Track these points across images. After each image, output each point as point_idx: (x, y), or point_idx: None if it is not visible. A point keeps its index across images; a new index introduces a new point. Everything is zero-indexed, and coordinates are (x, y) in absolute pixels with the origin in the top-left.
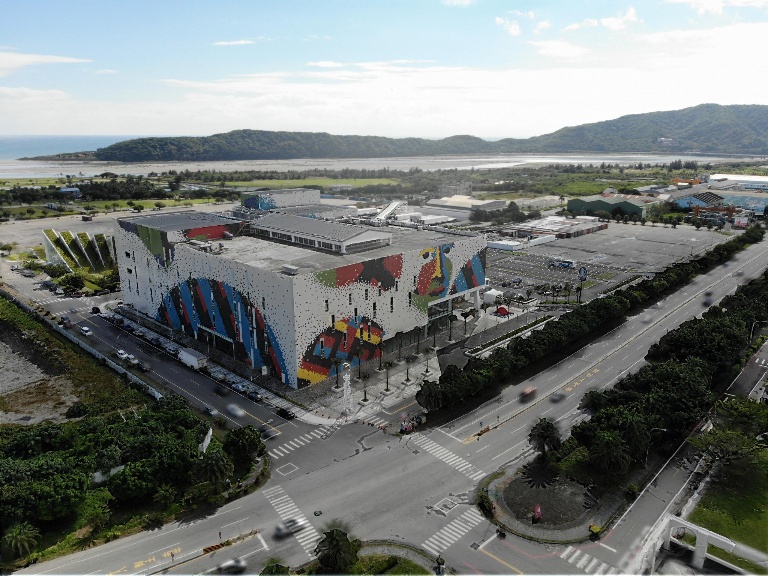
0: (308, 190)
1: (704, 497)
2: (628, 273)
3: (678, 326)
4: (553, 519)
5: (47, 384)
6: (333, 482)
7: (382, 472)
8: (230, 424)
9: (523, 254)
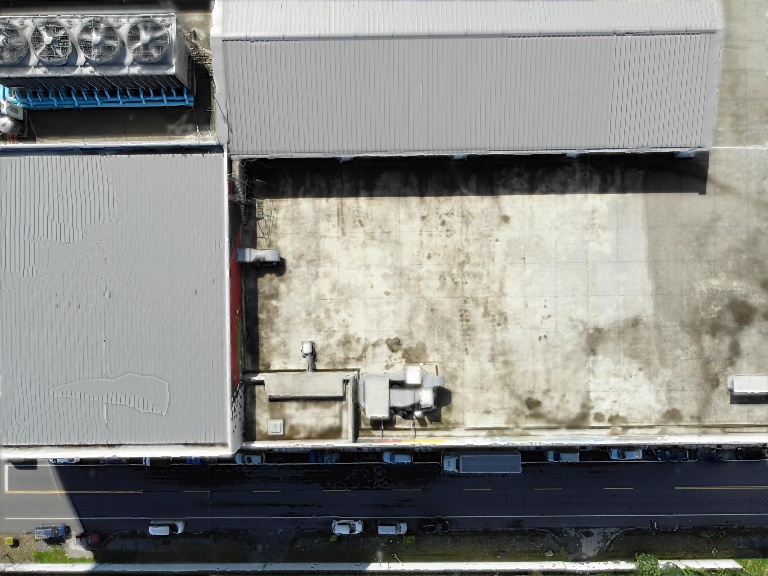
0: None
1: None
2: None
3: None
4: None
5: None
6: None
7: None
8: (715, 523)
9: None
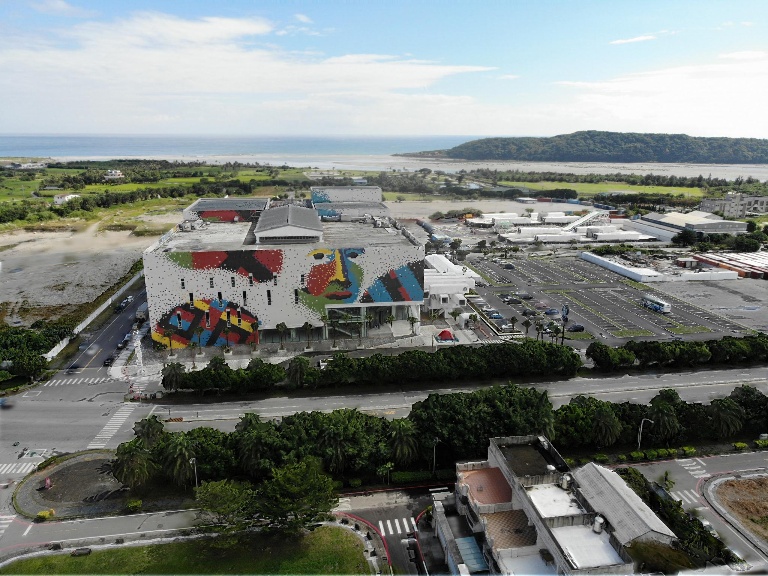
0: (369, 188)
1: (170, 544)
2: (734, 333)
3: None
4: (50, 494)
5: (65, 307)
6: (28, 411)
7: (60, 417)
8: (75, 357)
9: (643, 287)
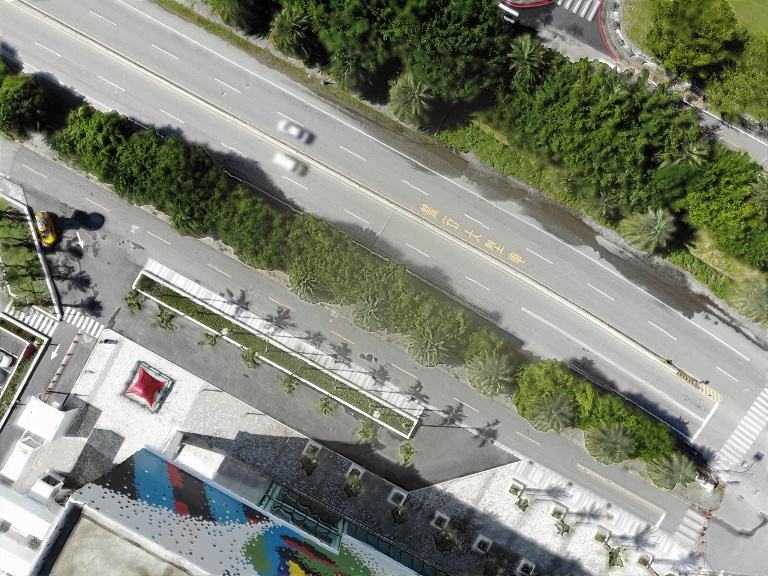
0: None
1: None
2: None
3: (139, 22)
4: None
5: None
6: None
7: None
8: None
9: None
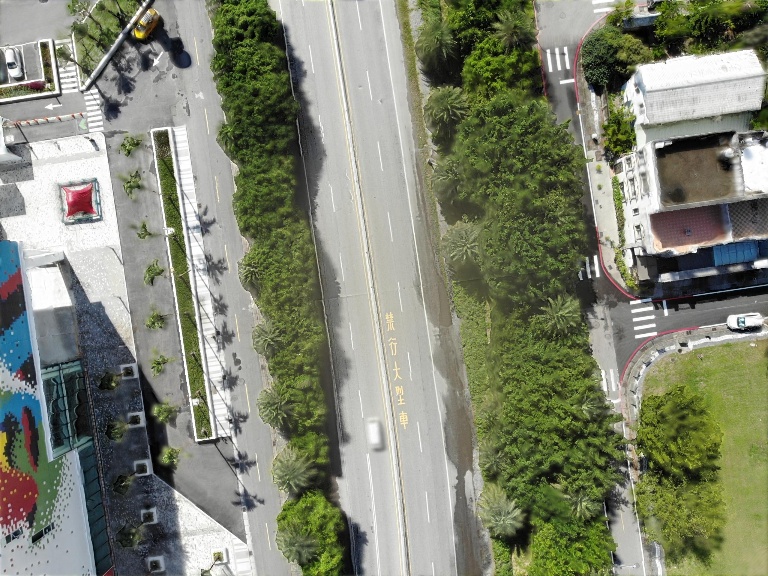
0: None
1: None
2: None
3: None
4: None
5: None
6: None
7: None
8: None
9: None
